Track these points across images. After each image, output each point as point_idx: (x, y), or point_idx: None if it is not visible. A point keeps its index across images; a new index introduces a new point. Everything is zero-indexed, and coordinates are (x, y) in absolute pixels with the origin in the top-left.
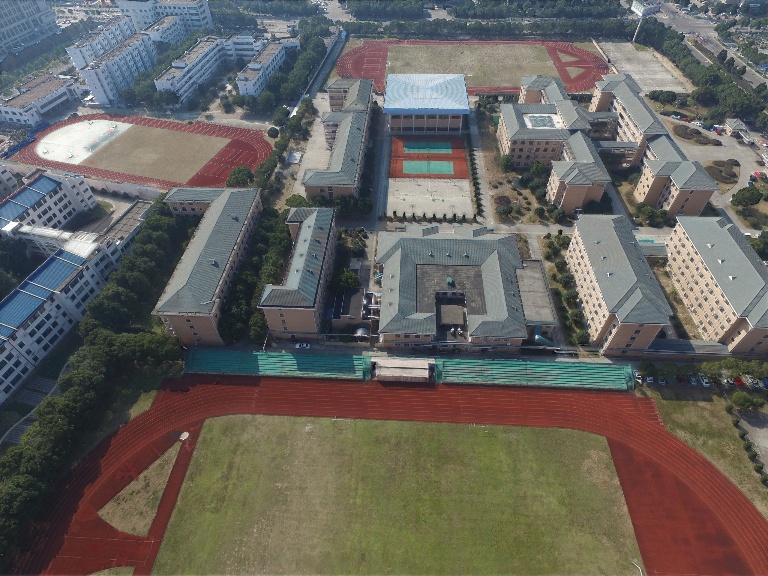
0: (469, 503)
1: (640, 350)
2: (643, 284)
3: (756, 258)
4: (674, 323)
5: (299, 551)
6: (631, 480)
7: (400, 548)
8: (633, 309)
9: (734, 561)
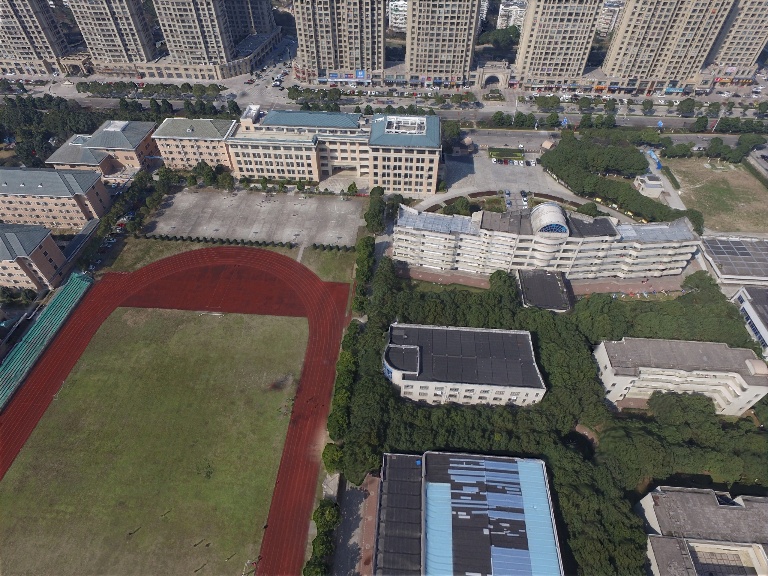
0: (119, 409)
1: (65, 263)
2: (4, 229)
3: (36, 169)
4: (59, 239)
5: (89, 572)
6: (153, 301)
7: (128, 469)
8: (21, 244)
9: (216, 270)
